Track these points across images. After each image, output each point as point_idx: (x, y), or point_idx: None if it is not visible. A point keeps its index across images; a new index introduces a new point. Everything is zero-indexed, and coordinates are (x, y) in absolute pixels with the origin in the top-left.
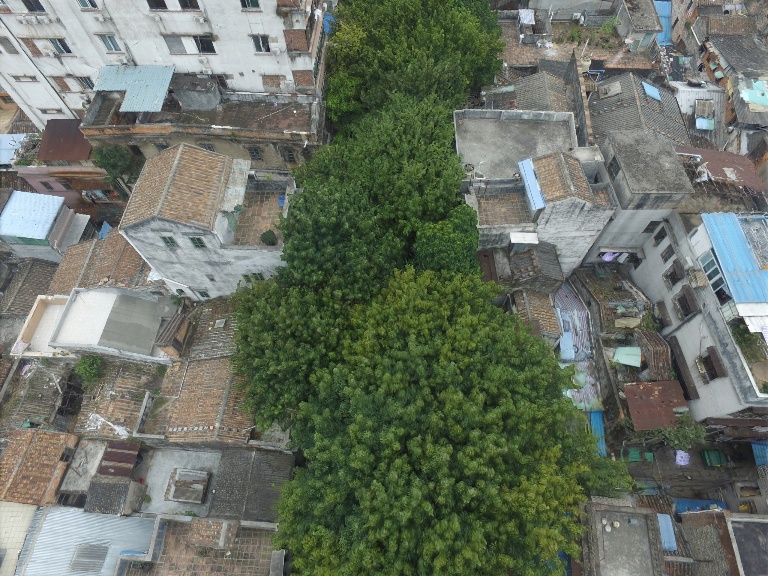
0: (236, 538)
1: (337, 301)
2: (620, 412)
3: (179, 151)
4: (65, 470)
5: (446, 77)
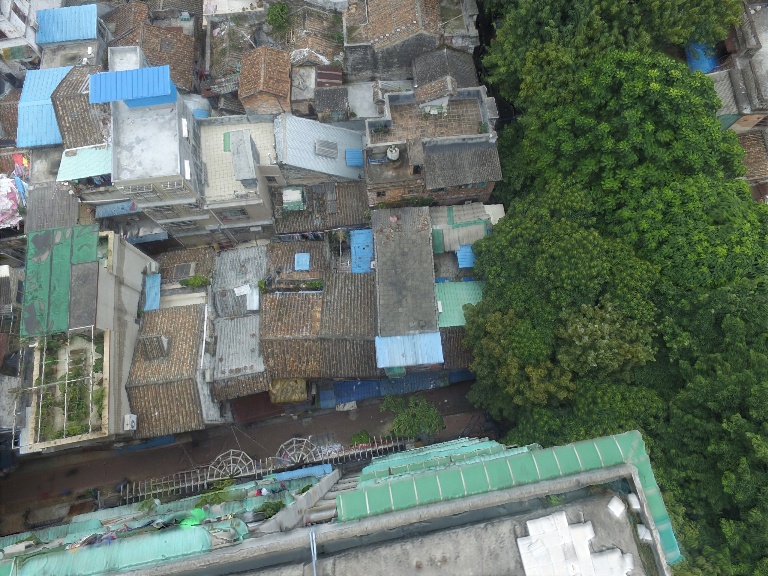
0: (447, 106)
1: None
2: None
3: None
4: (290, 86)
5: None
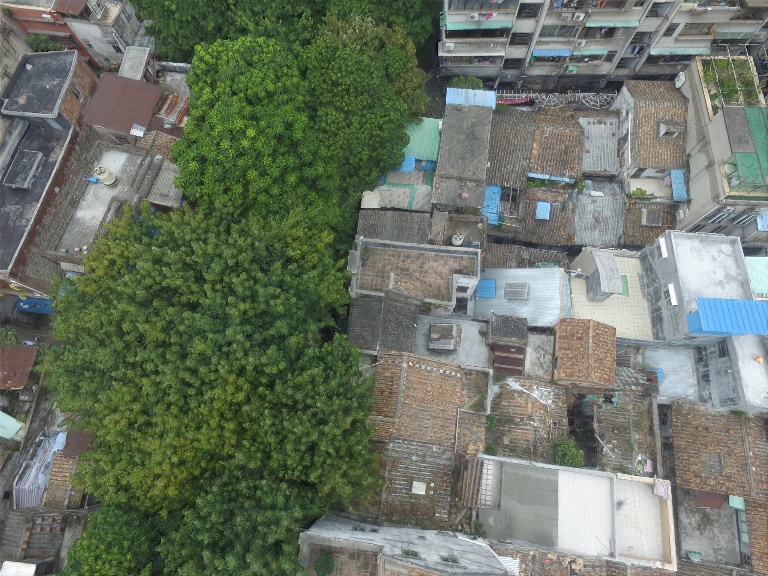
0: None
1: (245, 451)
2: None
3: None
4: (555, 352)
5: None
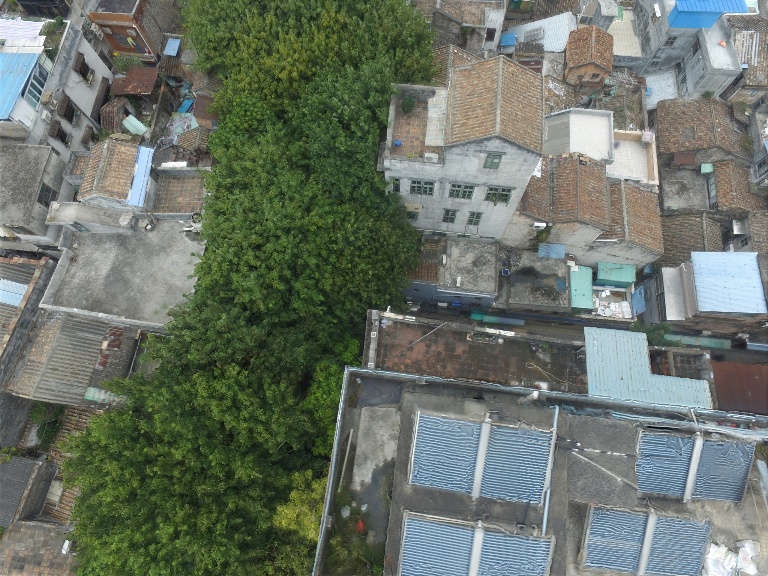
0: None
1: None
2: (163, 91)
3: (499, 125)
4: None
5: (177, 305)
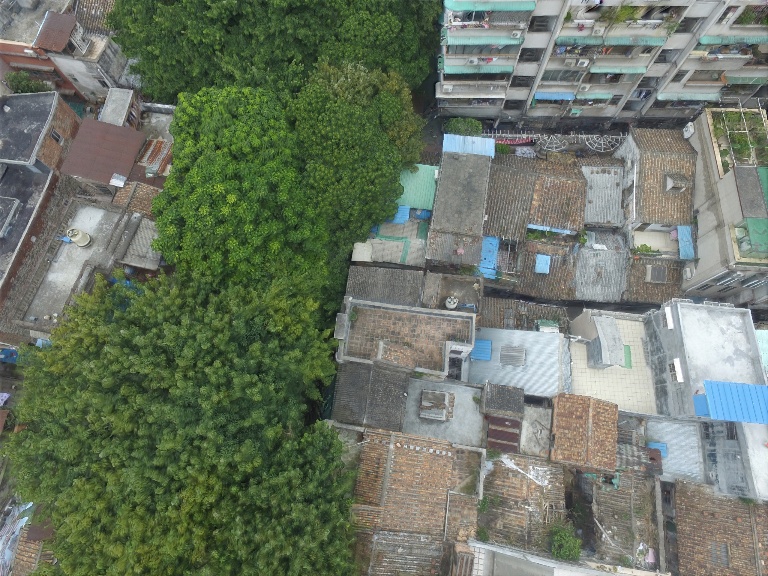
0: None
1: (214, 562)
2: None
3: None
4: (553, 427)
5: None
